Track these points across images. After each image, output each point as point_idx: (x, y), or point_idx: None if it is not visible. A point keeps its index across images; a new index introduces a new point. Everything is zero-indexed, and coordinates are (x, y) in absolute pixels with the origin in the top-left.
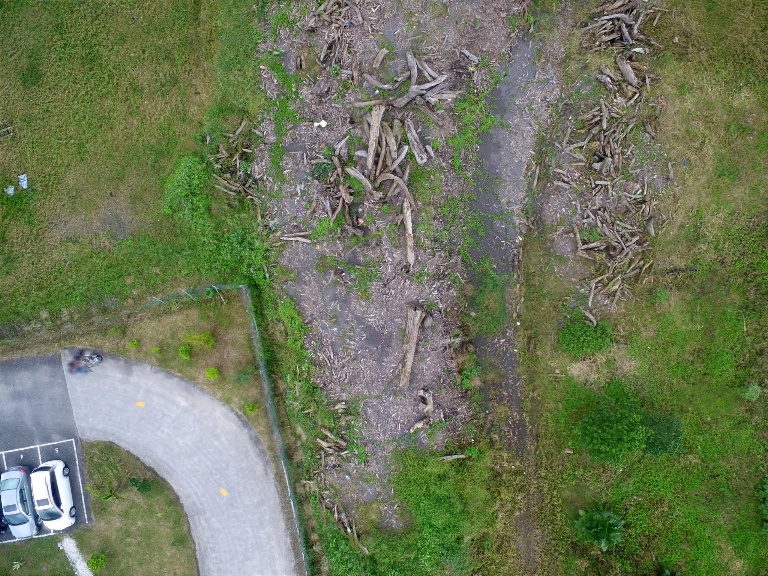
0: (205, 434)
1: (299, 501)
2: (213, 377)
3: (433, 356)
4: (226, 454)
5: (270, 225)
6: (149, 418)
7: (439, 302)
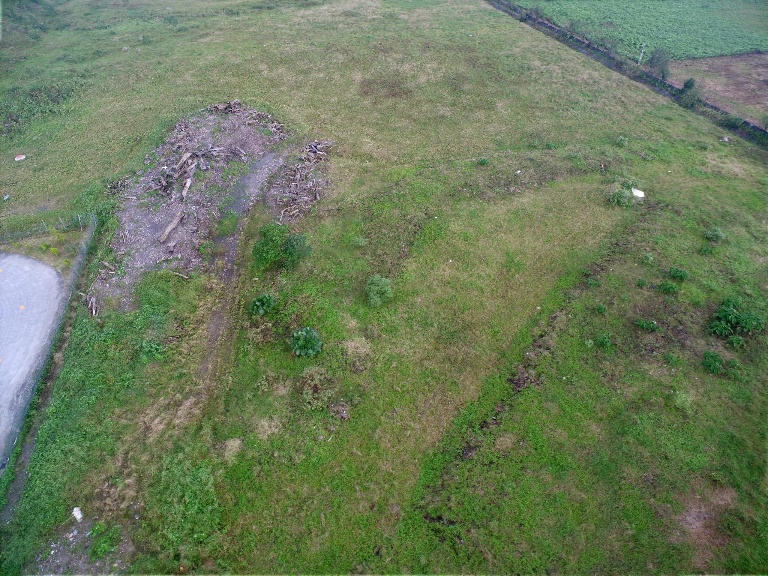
0: (30, 281)
1: (70, 309)
2: (54, 251)
3: (183, 232)
4: (37, 289)
5: (122, 196)
6: (0, 276)
7: (195, 213)
